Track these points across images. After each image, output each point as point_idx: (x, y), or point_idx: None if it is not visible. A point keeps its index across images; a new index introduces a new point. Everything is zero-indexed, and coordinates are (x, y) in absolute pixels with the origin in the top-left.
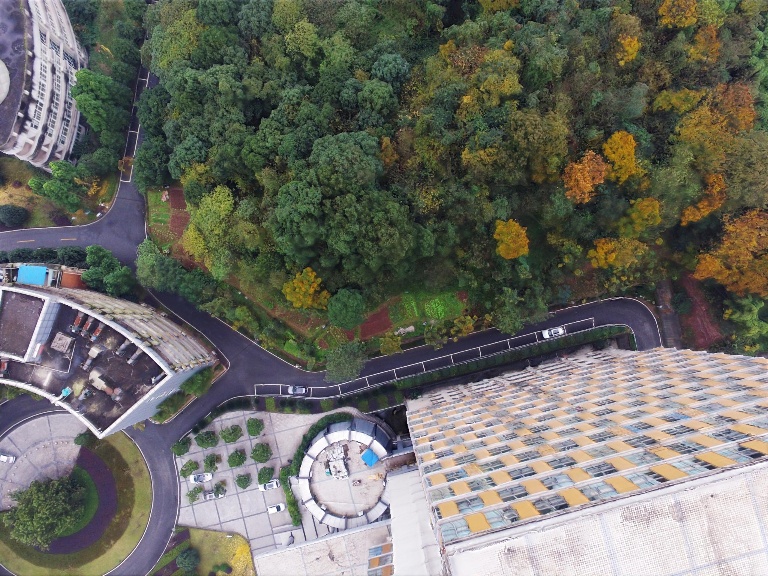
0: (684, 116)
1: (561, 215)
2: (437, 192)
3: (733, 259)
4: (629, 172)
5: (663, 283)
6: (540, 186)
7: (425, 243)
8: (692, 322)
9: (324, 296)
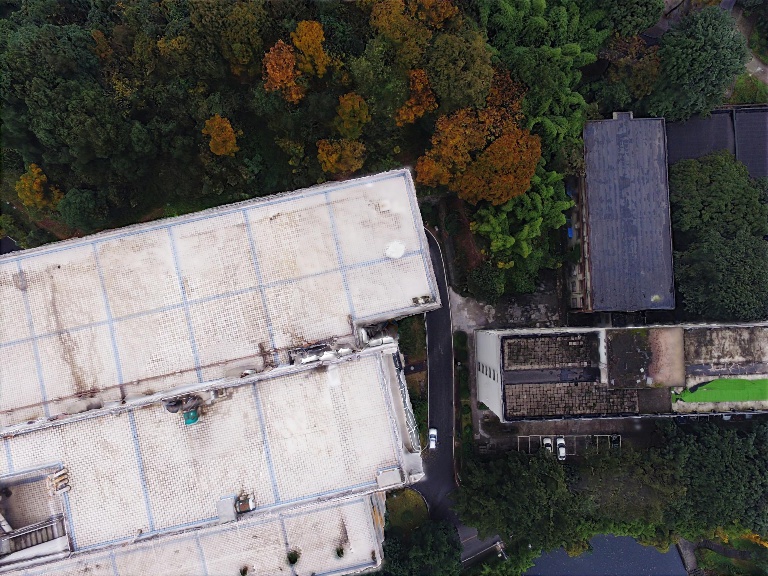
0: (374, 6)
1: (268, 110)
2: (142, 84)
3: (445, 159)
4: (321, 63)
5: (441, 206)
6: (241, 79)
7: (133, 136)
8: (466, 245)
9: (57, 196)
